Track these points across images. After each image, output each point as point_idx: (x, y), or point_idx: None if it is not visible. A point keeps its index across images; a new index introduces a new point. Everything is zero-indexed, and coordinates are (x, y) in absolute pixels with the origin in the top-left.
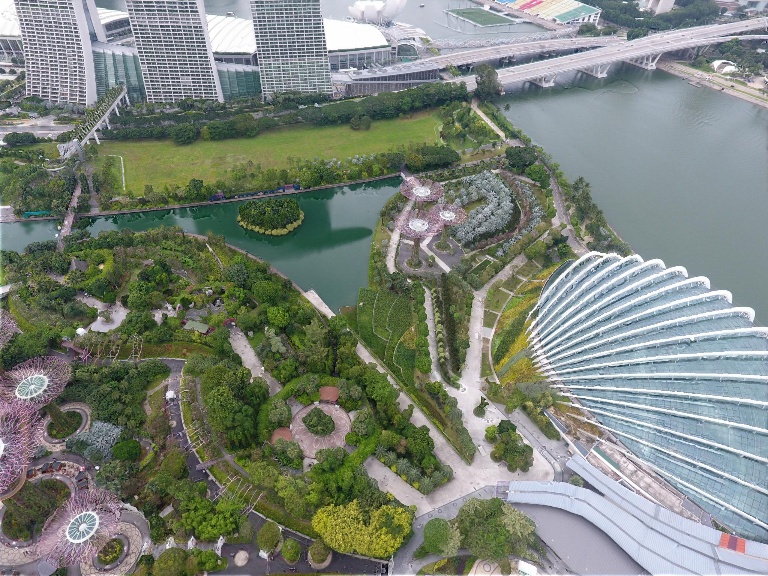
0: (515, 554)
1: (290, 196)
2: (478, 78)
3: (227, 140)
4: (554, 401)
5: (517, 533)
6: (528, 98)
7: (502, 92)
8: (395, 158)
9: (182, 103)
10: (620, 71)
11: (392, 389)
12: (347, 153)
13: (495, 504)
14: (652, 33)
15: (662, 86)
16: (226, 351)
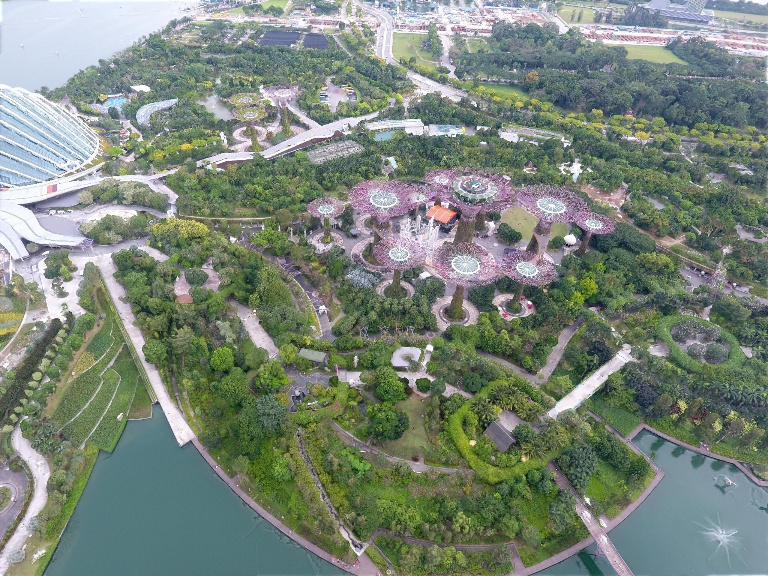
0: None
1: None
2: None
3: None
4: None
5: (92, 222)
6: None
7: None
8: None
9: None
10: None
11: None
12: None
13: (96, 230)
14: None
15: None
16: None
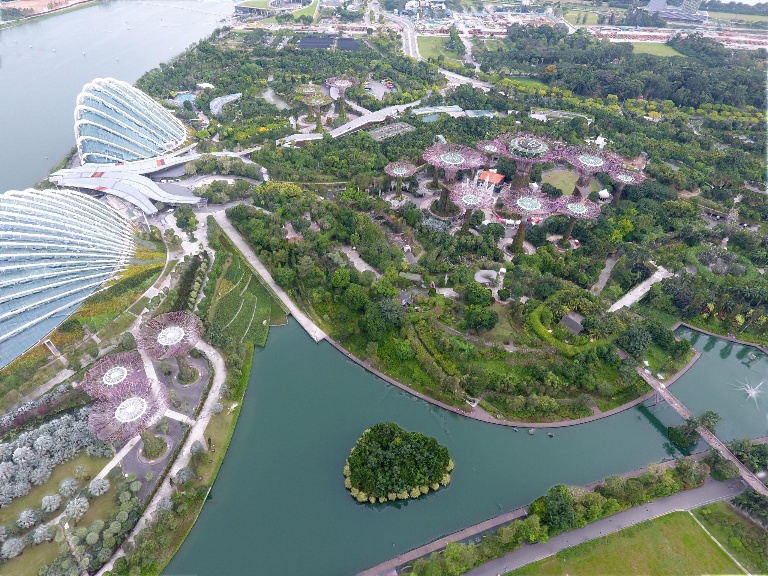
0: None
1: None
2: None
3: None
4: None
5: None
6: None
7: None
8: None
9: None
10: None
11: (250, 224)
12: None
13: (210, 191)
14: None
15: None
16: None
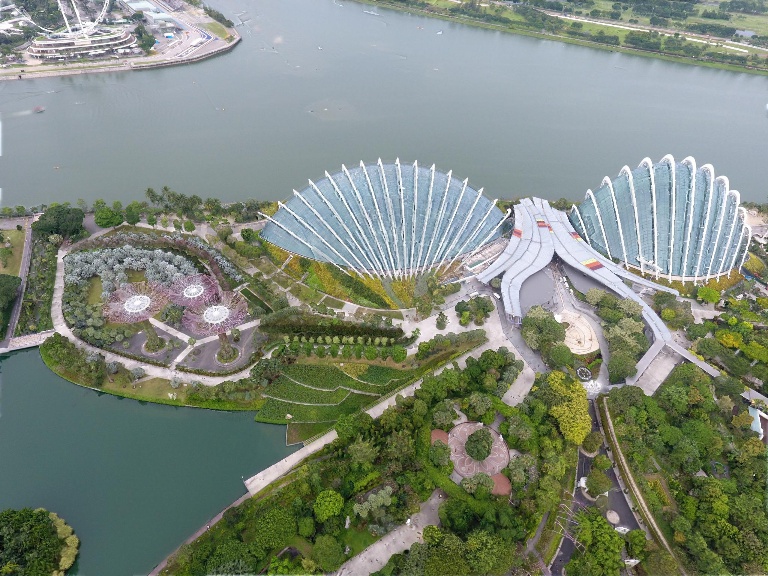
0: None
1: None
2: None
3: None
4: None
5: (546, 314)
6: None
7: None
8: None
9: None
10: None
11: None
12: None
13: (531, 320)
14: None
15: None
16: (389, 575)
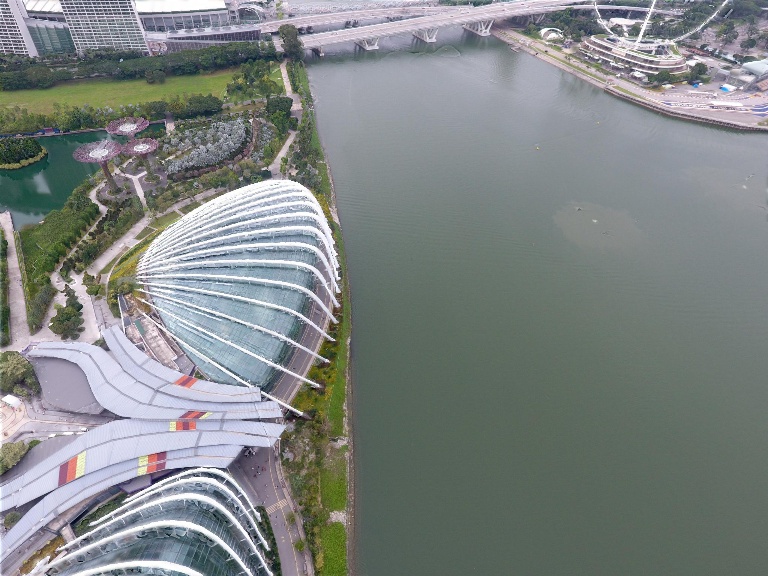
0: (3, 389)
1: (55, 139)
2: (285, 38)
3: (20, 91)
4: (133, 289)
5: (8, 373)
6: (345, 59)
7: (321, 53)
8: (156, 105)
9: None
10: (463, 38)
11: None
12: (127, 103)
13: (4, 354)
14: (495, 2)
15: (495, 52)
16: None
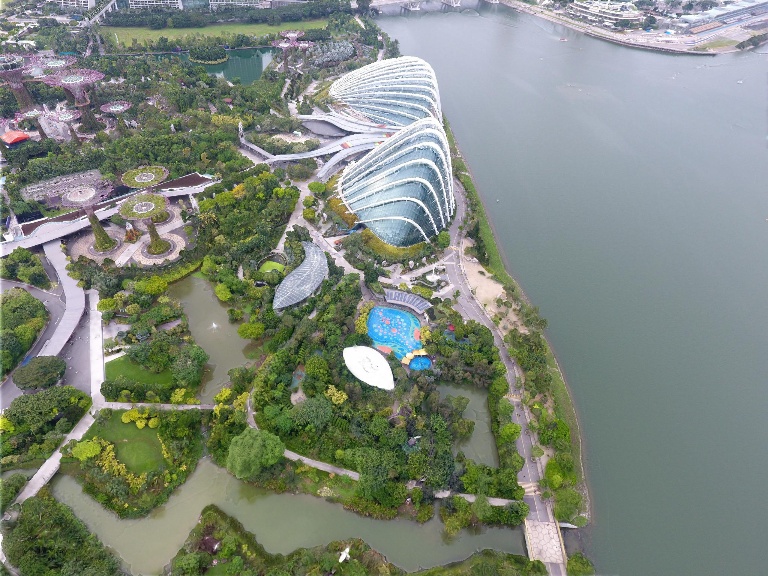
0: (293, 128)
1: None
2: None
3: (184, 28)
4: (332, 101)
5: (294, 121)
6: (398, 16)
7: (380, 11)
8: None
9: (154, 9)
10: (478, 6)
11: (254, 92)
12: None
13: (288, 115)
14: None
15: (503, 15)
16: None
